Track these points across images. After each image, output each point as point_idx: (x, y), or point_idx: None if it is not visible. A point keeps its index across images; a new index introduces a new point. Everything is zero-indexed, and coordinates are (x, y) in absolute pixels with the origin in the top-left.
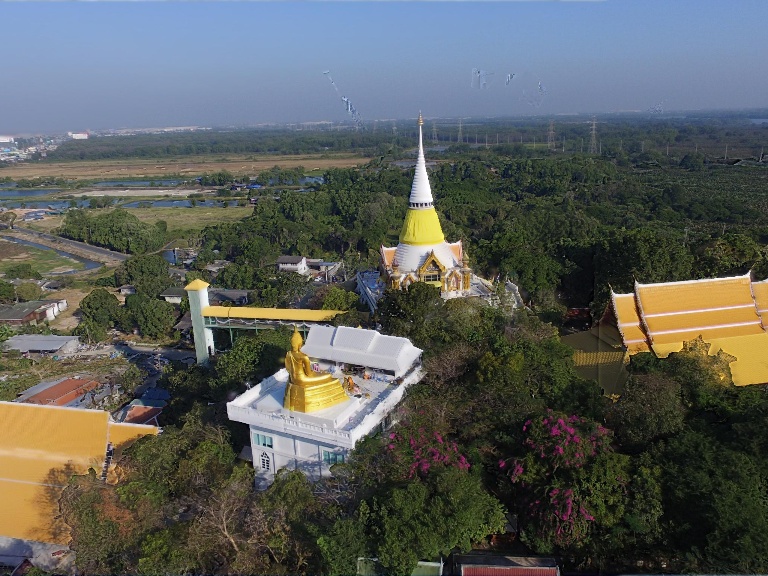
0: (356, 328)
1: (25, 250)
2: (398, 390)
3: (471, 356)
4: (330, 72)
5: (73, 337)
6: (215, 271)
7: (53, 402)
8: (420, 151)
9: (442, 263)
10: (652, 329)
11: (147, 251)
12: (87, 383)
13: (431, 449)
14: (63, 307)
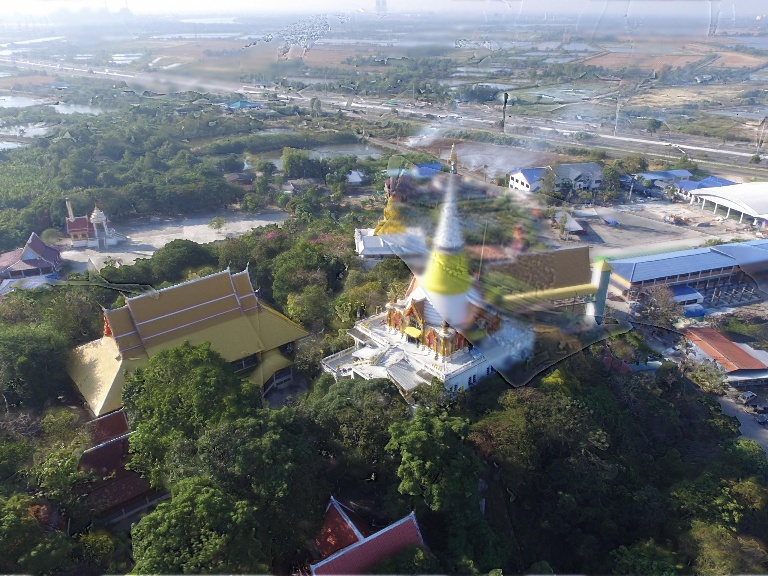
0: None
1: None
2: None
3: None
4: (357, 81)
5: None
6: None
7: (708, 345)
8: None
9: None
10: None
11: None
12: (735, 364)
13: None
14: None
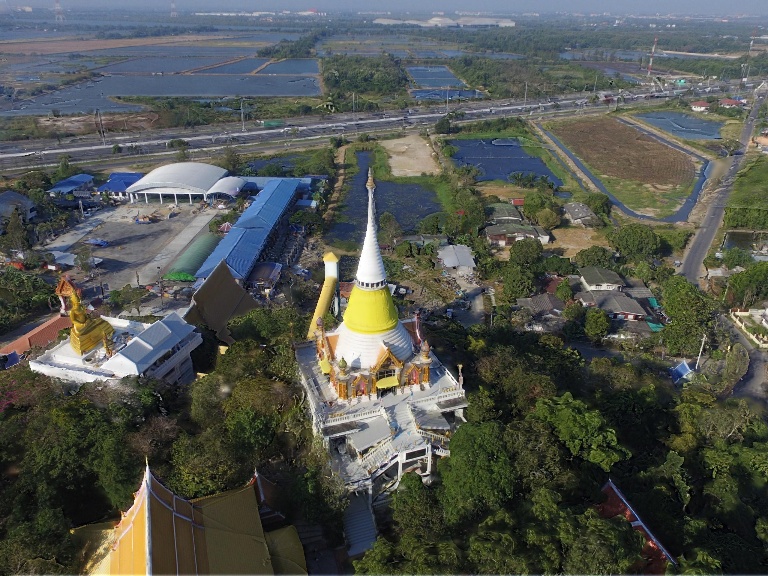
0: (148, 327)
1: (681, 182)
2: (91, 376)
3: (101, 396)
4: None
5: (470, 264)
6: (708, 277)
7: (347, 292)
8: (369, 218)
9: (339, 352)
10: (122, 541)
11: (747, 226)
12: None
13: (5, 401)
14: (544, 241)
